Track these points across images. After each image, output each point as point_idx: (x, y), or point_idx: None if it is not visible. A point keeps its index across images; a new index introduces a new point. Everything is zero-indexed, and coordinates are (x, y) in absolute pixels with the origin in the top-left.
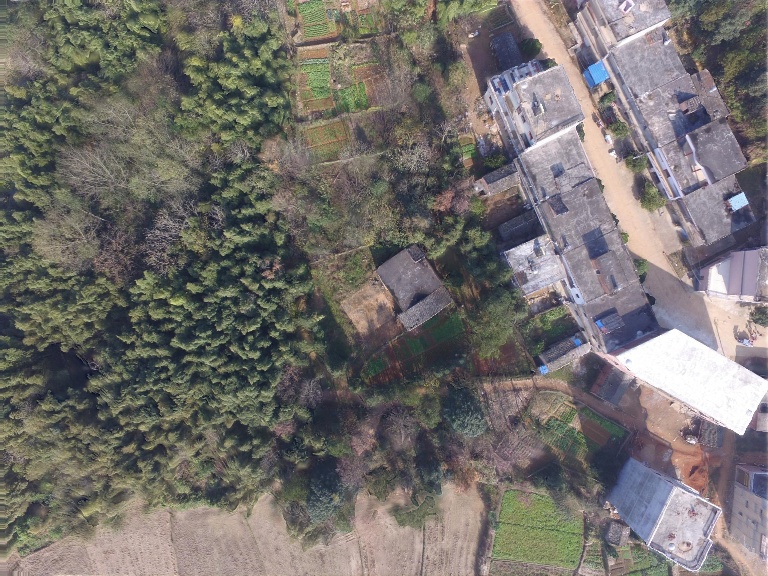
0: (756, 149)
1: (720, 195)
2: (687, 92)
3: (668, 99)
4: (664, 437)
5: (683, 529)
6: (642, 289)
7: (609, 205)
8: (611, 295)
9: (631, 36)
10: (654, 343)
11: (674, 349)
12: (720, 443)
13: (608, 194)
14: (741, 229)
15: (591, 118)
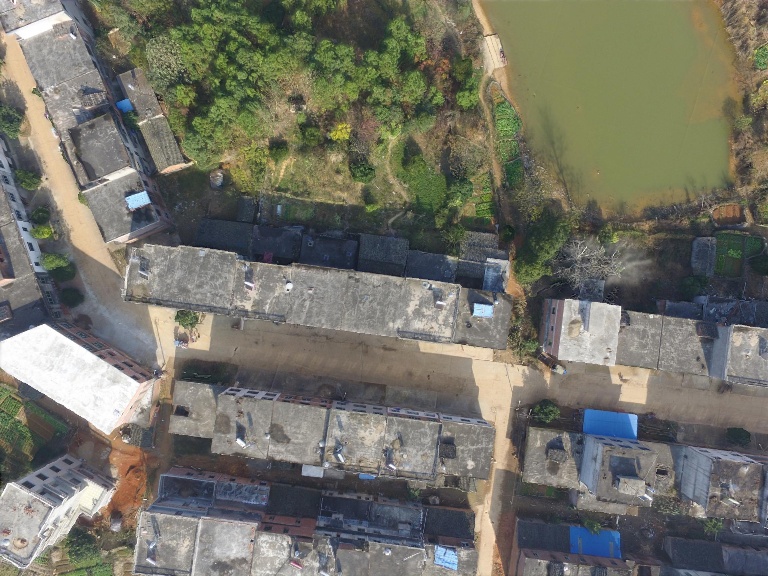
0: (183, 149)
1: (122, 193)
2: (94, 88)
3: (74, 94)
4: (105, 435)
5: (19, 525)
6: (37, 283)
7: (56, 199)
8: (5, 288)
9: (21, 28)
10: (22, 337)
11: (42, 345)
12: (147, 444)
13: (55, 188)
14: (187, 230)
15: (44, 111)
